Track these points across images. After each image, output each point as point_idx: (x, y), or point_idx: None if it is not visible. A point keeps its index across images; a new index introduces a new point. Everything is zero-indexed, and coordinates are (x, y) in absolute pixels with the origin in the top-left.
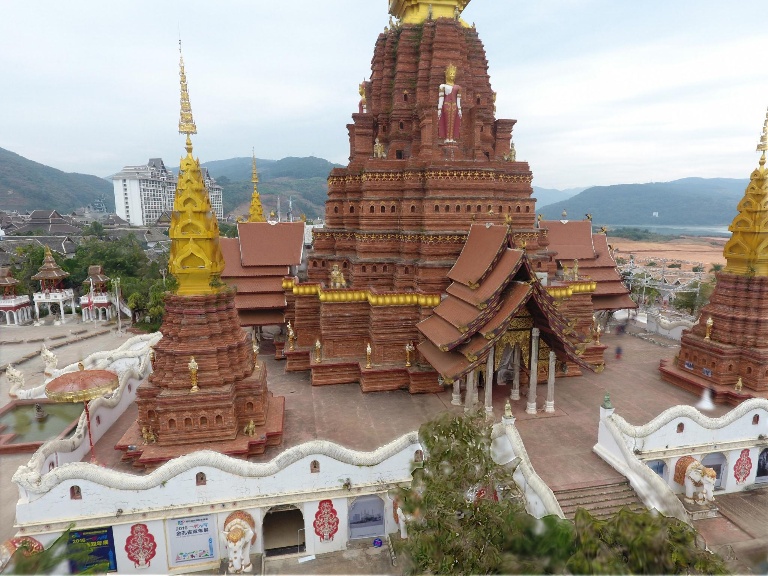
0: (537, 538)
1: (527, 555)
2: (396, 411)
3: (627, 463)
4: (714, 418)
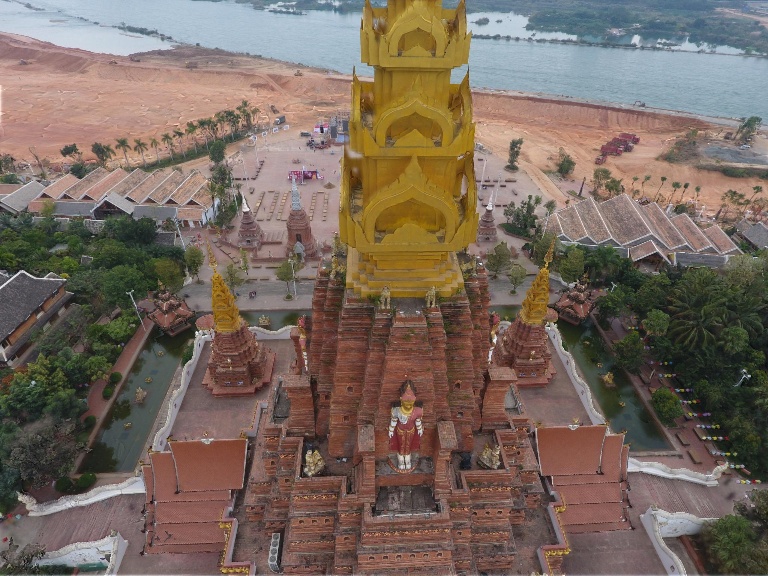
0: (748, 536)
1: (756, 543)
2: (590, 573)
3: (638, 467)
4: (594, 409)
